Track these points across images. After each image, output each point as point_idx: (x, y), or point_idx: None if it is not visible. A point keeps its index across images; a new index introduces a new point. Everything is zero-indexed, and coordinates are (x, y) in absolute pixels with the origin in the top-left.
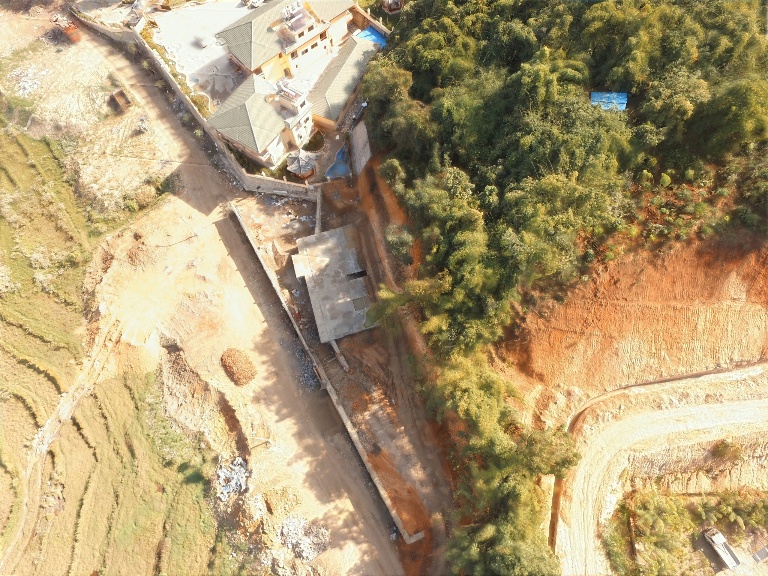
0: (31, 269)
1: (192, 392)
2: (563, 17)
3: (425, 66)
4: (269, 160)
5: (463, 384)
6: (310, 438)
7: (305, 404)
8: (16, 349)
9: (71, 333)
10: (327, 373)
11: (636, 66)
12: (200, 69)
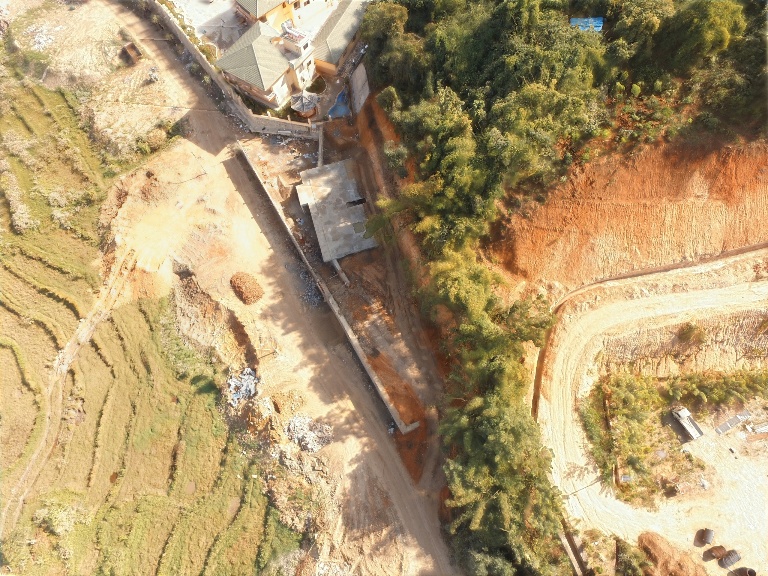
0: (49, 207)
1: (203, 312)
2: None
3: (419, 3)
4: (274, 101)
5: (454, 274)
6: (314, 348)
7: (309, 319)
8: (36, 280)
9: (88, 265)
10: (329, 288)
11: None
12: (207, 22)
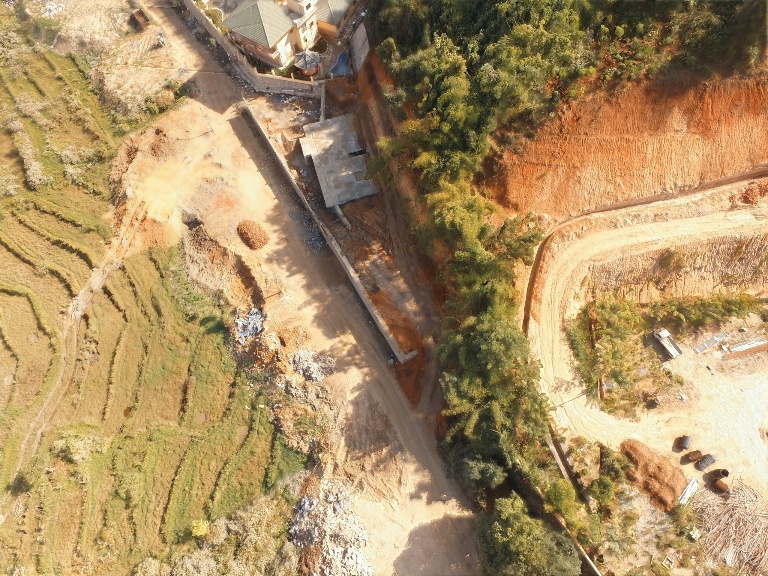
0: (62, 165)
1: (211, 259)
2: None
3: None
4: (278, 61)
5: (449, 204)
6: (317, 288)
7: (312, 262)
8: (50, 233)
9: (100, 218)
10: (332, 232)
11: None
12: None
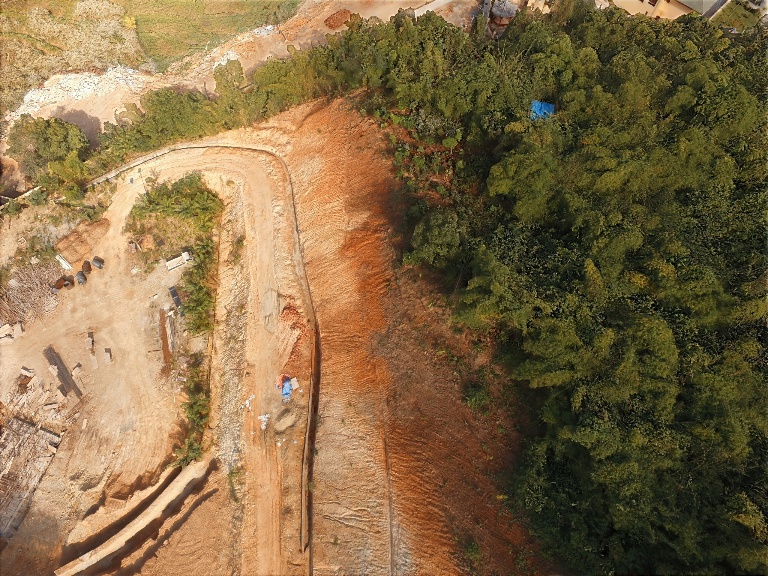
0: None
1: None
2: None
3: None
4: None
5: (289, 61)
6: None
7: None
8: None
9: None
10: None
11: (574, 106)
12: None
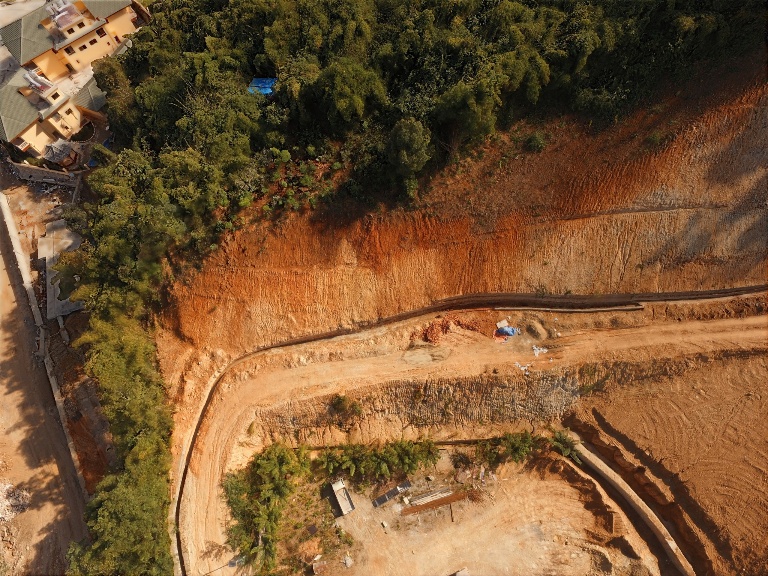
0: None
1: None
2: (231, 10)
3: (138, 57)
4: (35, 150)
5: (98, 346)
6: (32, 409)
7: (35, 377)
8: None
9: None
10: (50, 347)
11: (274, 53)
12: None
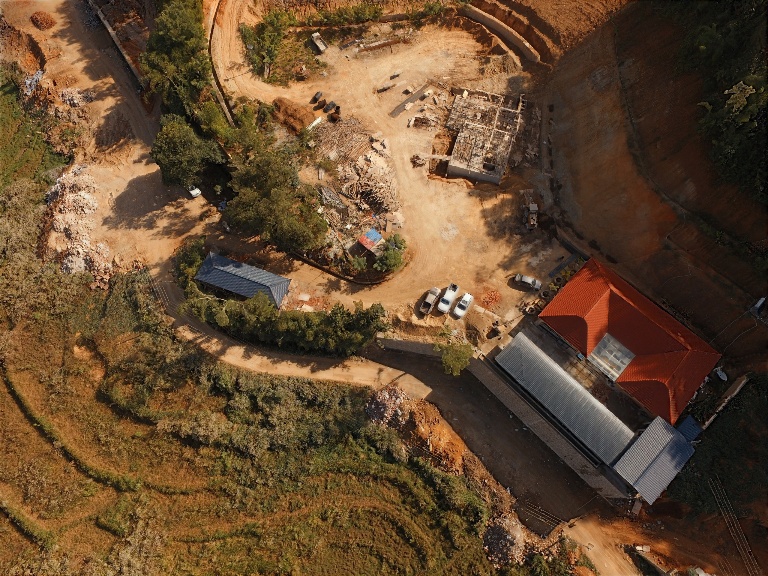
0: None
1: (11, 43)
2: None
3: None
4: None
5: None
6: (89, 51)
7: (89, 36)
8: None
9: None
10: None
11: None
12: None
